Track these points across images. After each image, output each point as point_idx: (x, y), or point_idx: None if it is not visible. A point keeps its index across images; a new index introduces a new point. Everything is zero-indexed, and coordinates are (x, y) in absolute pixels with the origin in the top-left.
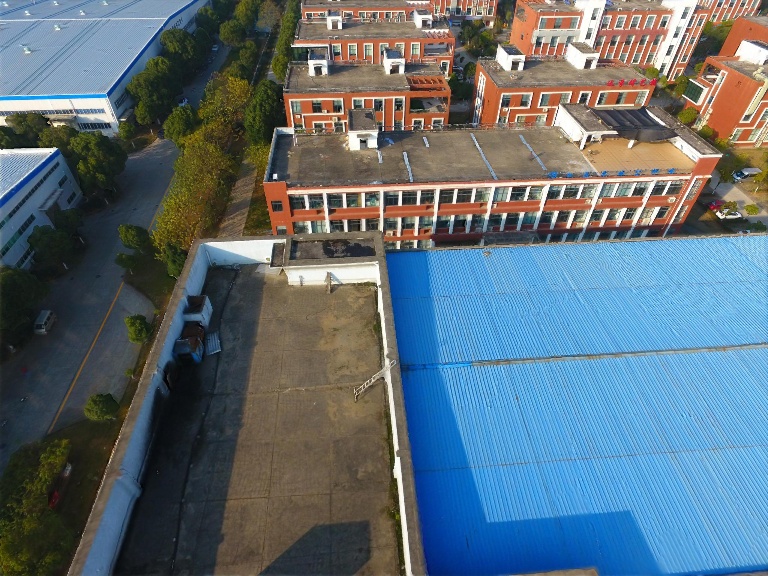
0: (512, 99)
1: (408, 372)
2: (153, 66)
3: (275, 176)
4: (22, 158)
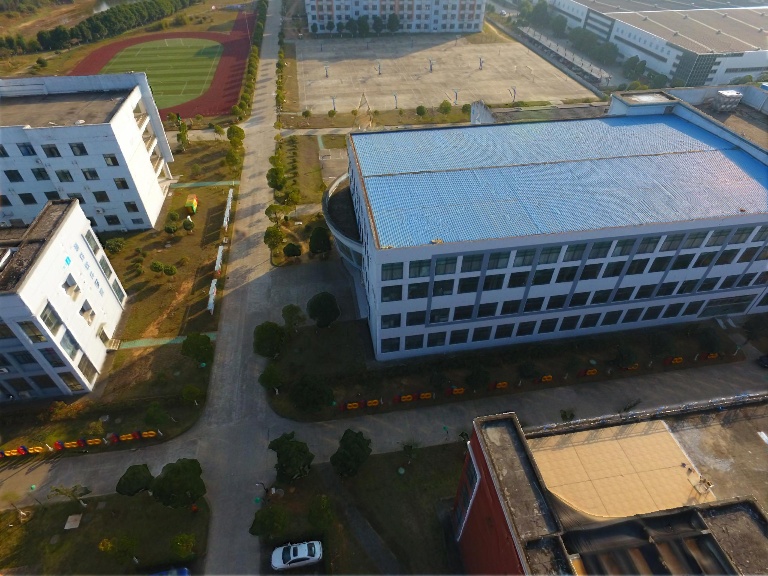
0: None
1: (731, 147)
2: None
3: None
4: None
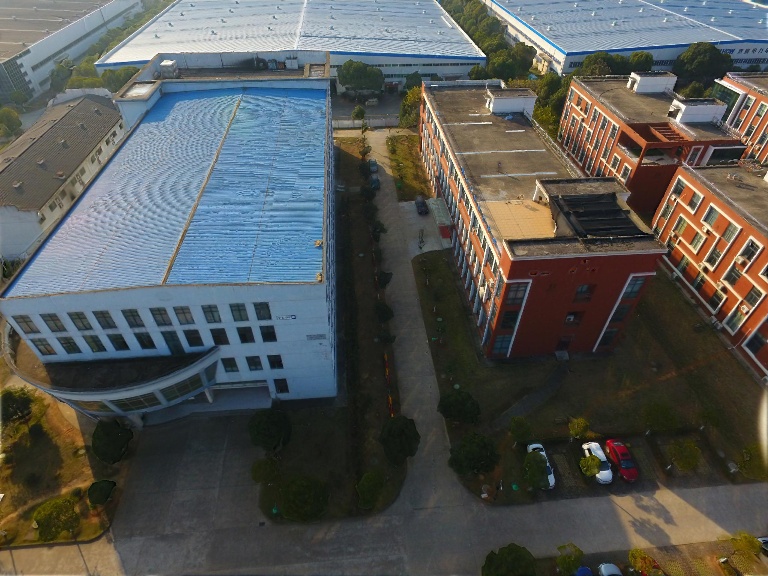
0: (685, 190)
1: None
2: (632, 56)
3: (434, 85)
4: (473, 53)
